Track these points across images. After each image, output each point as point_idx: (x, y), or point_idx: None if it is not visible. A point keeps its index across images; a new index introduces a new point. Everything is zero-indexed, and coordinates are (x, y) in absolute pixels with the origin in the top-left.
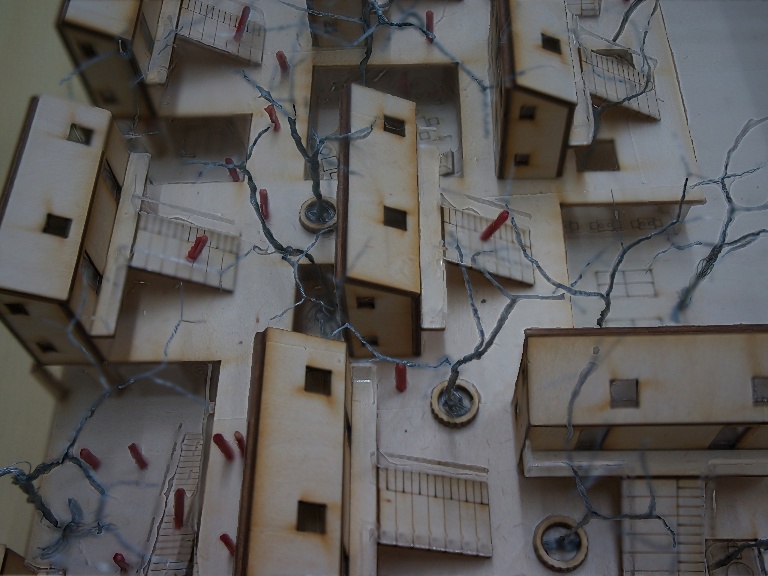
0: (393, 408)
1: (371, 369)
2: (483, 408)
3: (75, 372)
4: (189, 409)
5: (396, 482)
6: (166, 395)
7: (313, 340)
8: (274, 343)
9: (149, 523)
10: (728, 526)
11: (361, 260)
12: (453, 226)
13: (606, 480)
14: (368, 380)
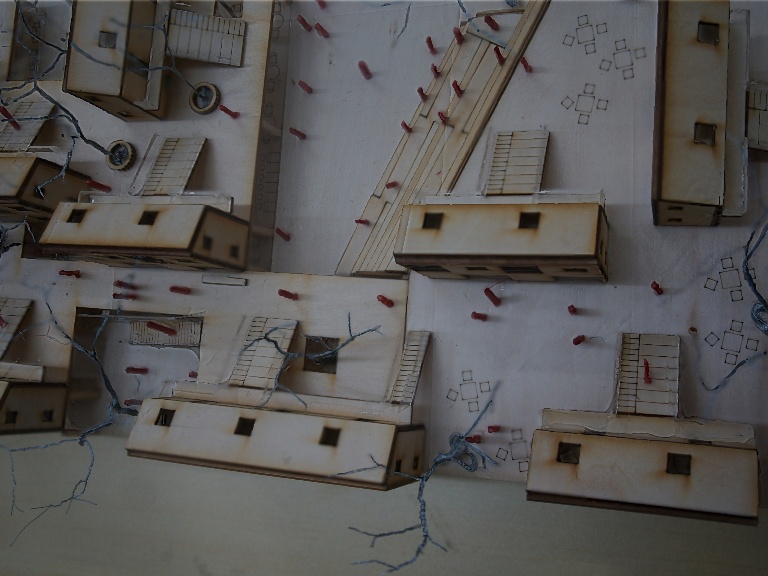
0: (120, 195)
1: (82, 194)
2: (127, 139)
3: (77, 417)
4: (114, 343)
5: (153, 186)
6: (103, 359)
7: (53, 219)
8: (49, 239)
9: (180, 365)
10: (208, 4)
11: (8, 188)
12: (6, 146)
13: (167, 64)
14: (92, 201)
